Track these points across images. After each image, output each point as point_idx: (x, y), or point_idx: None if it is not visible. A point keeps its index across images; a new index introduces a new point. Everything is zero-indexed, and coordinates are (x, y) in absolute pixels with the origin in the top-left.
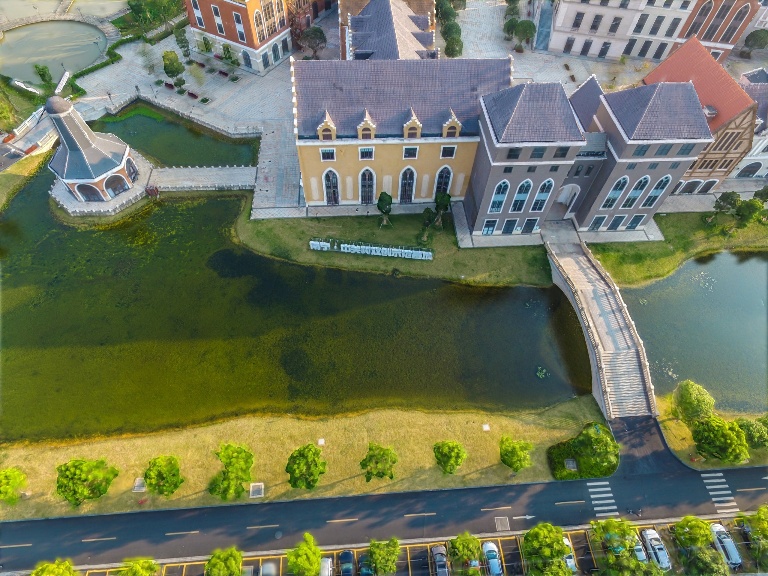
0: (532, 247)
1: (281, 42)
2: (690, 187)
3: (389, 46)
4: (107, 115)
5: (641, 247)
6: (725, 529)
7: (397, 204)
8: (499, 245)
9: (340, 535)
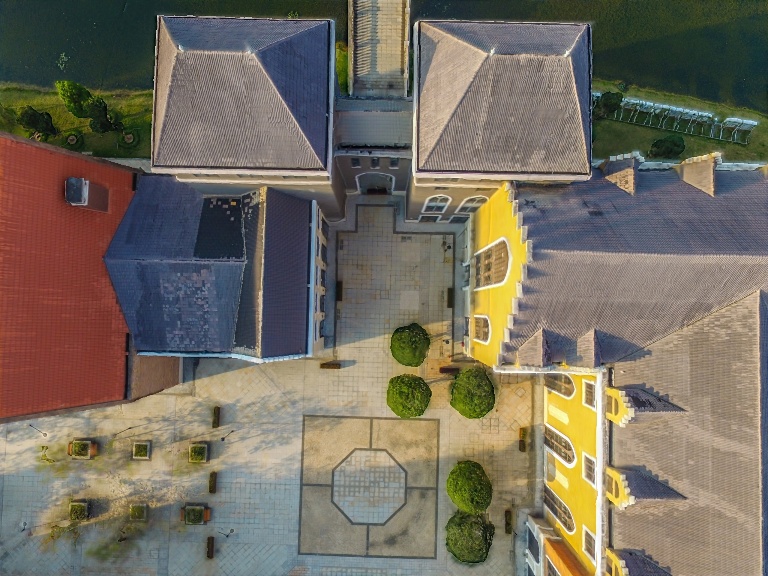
0: None
1: None
2: None
3: None
4: None
5: None
6: None
7: None
8: None
9: None
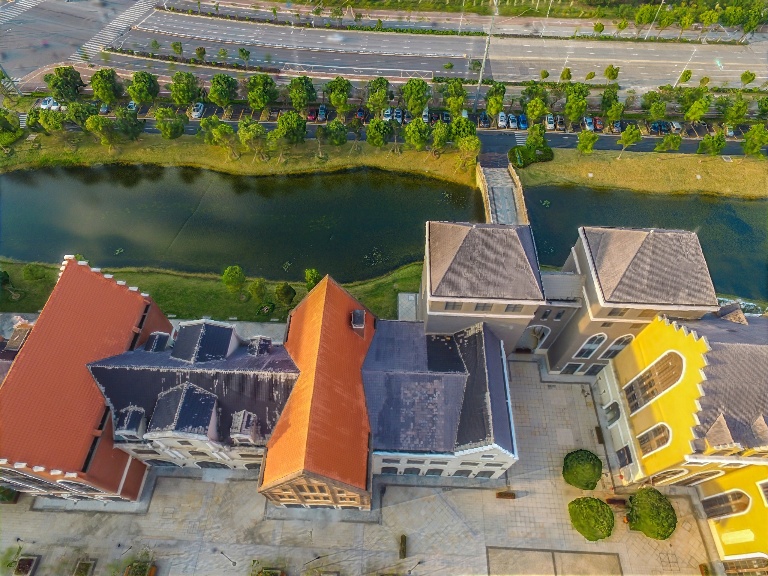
0: None
1: None
2: None
3: None
4: None
5: None
6: None
7: None
8: None
9: None
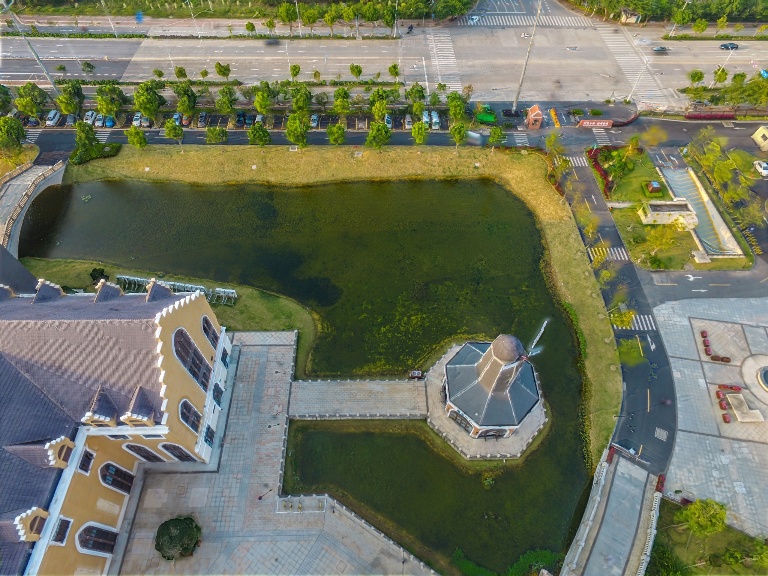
0: None
1: None
2: None
3: None
4: (555, 572)
5: None
6: None
7: None
8: None
9: None
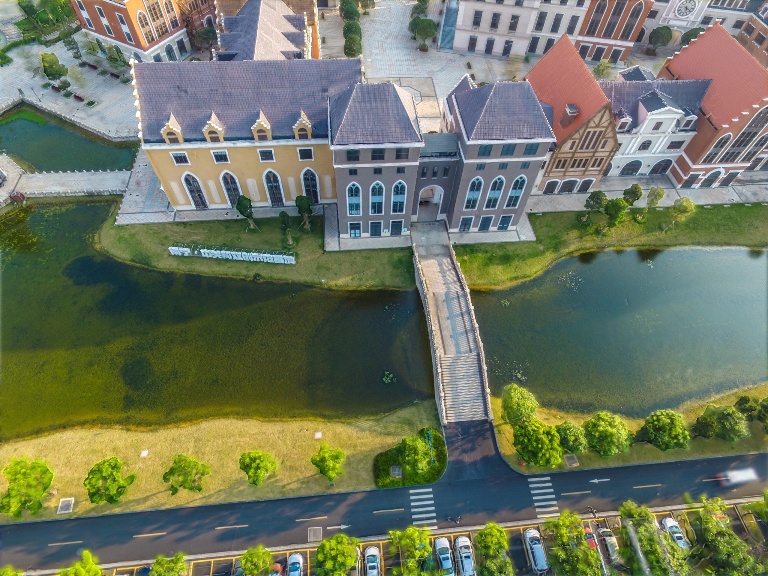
0: (399, 249)
1: (176, 43)
2: (568, 186)
3: (249, 47)
4: None
5: (510, 248)
6: (540, 534)
7: (269, 207)
8: (366, 248)
9: (144, 550)
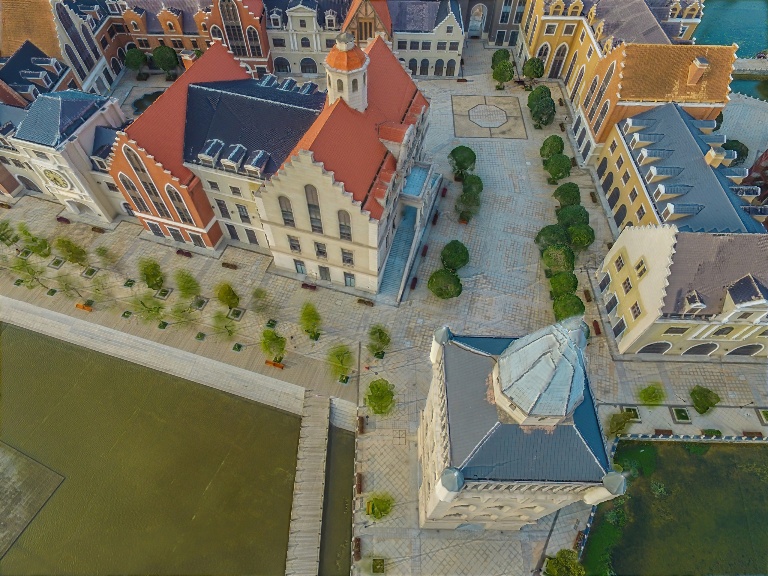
0: None
1: None
2: None
3: None
4: None
5: None
6: None
7: None
8: None
9: None
